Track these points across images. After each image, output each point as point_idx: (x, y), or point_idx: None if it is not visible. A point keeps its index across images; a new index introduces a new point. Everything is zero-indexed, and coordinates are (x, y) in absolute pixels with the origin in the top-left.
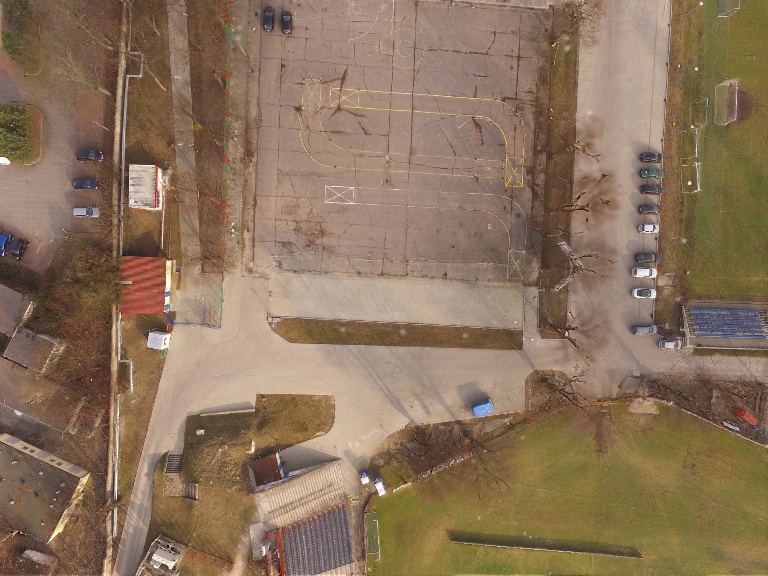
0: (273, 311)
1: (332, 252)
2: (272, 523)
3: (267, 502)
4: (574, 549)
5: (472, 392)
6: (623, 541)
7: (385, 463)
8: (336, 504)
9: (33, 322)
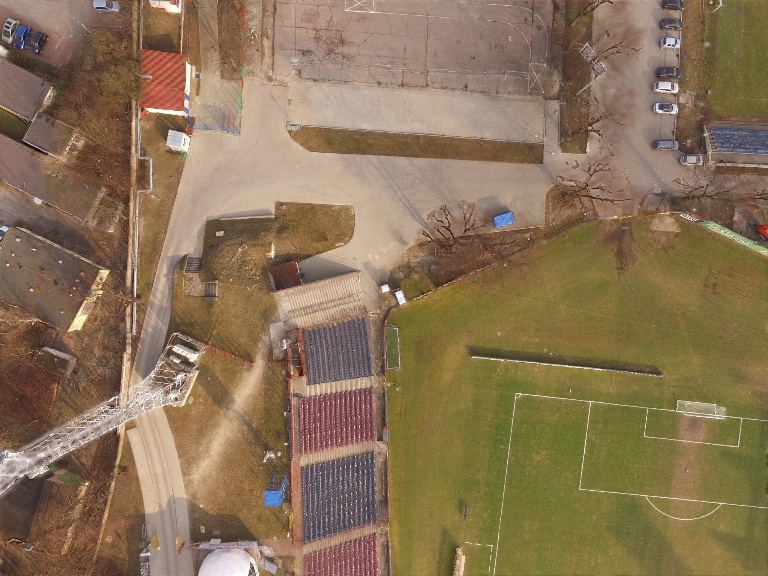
0: (293, 119)
1: (352, 61)
2: (292, 323)
3: (287, 301)
4: (595, 367)
5: (492, 205)
6: (644, 360)
7: (405, 276)
8: (356, 315)
9: (53, 109)
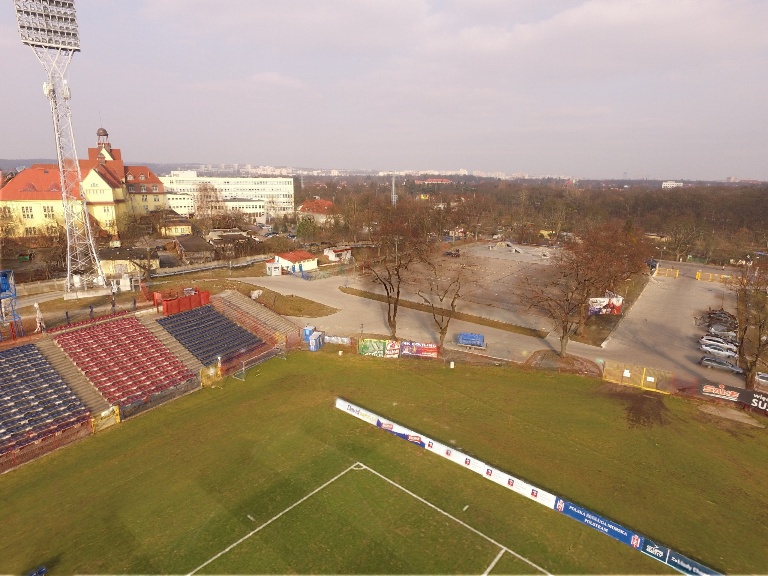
0: None
1: None
2: (212, 300)
3: (228, 295)
4: None
5: None
6: (681, 543)
7: None
8: (262, 338)
9: None
